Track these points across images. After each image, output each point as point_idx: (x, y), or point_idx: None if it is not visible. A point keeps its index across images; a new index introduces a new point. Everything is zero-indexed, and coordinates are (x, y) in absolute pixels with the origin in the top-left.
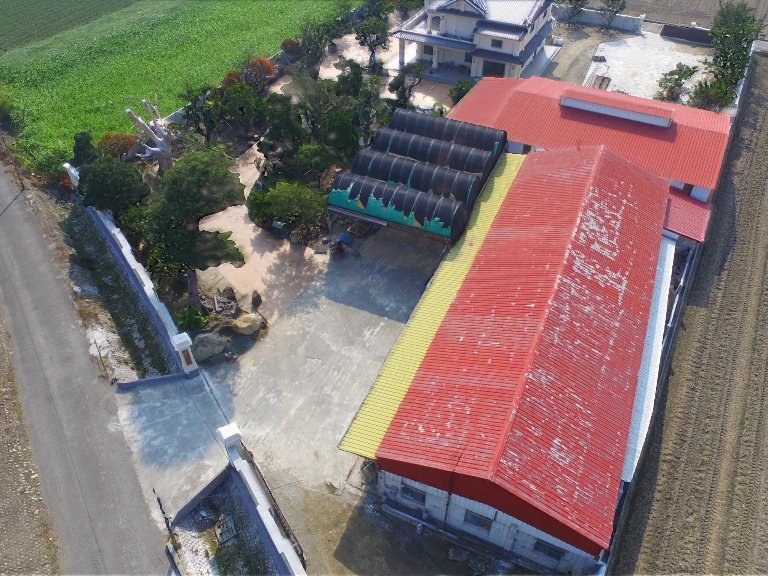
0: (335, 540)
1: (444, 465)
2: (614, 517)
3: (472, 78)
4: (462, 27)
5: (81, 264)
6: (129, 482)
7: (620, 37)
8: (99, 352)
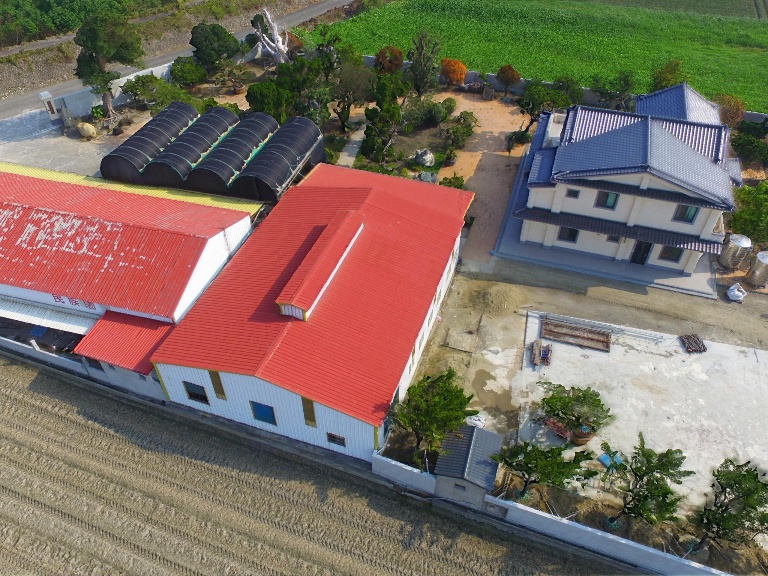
0: None
1: None
2: None
3: None
4: None
5: None
6: None
7: None
8: None
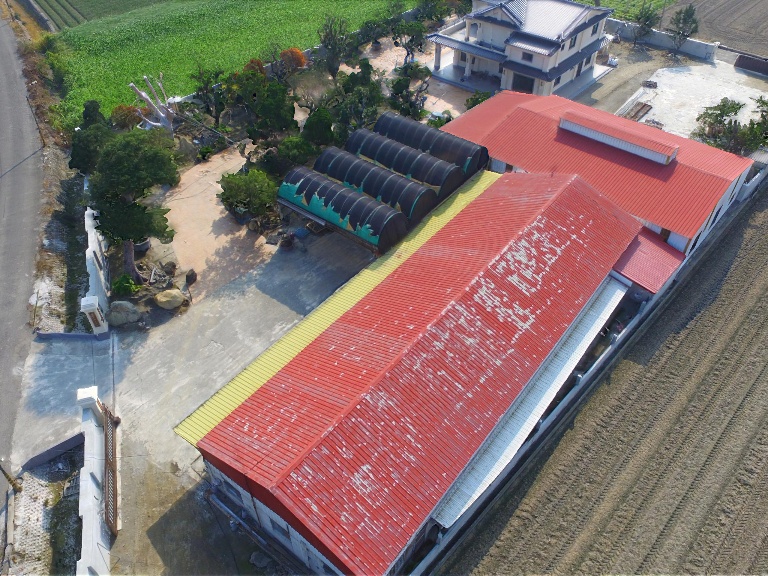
0: (155, 517)
1: (242, 466)
2: (434, 561)
3: (501, 90)
4: (498, 37)
5: (62, 220)
6: (6, 423)
7: (686, 64)
8: (37, 302)
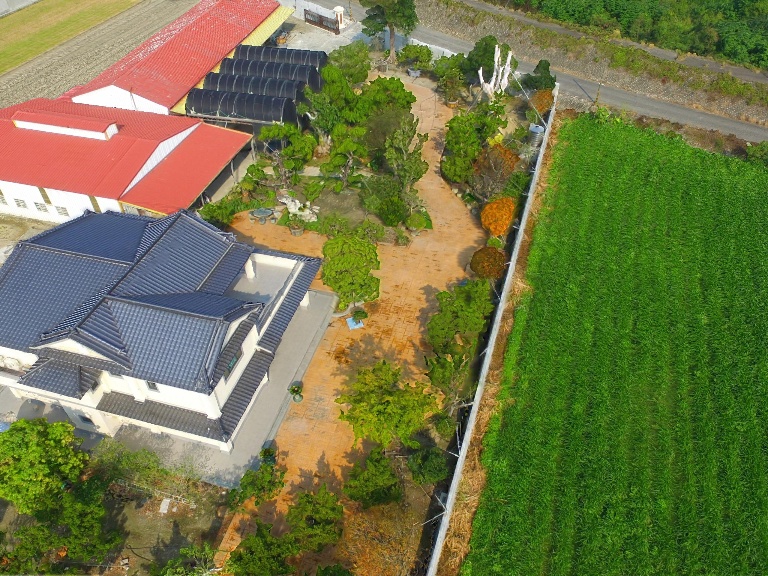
0: None
1: None
2: None
3: None
4: None
5: None
6: None
7: None
8: None
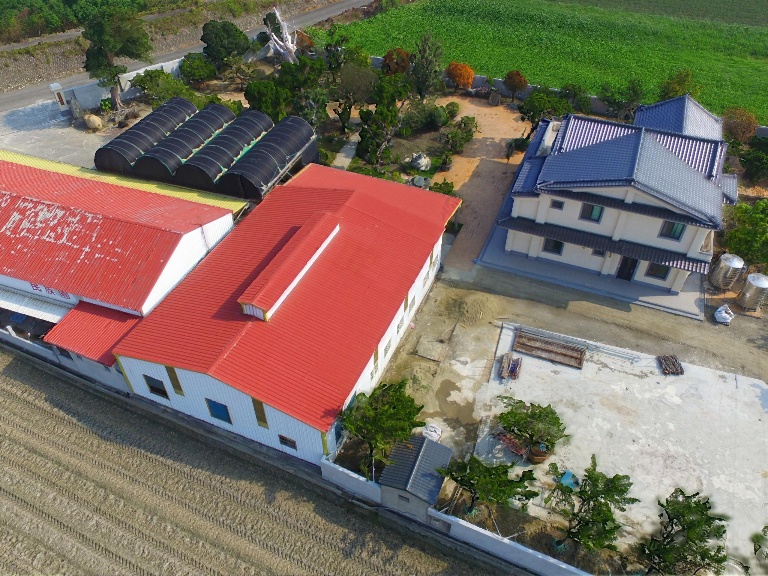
0: None
1: None
2: None
3: None
4: None
5: None
6: None
7: None
8: None
